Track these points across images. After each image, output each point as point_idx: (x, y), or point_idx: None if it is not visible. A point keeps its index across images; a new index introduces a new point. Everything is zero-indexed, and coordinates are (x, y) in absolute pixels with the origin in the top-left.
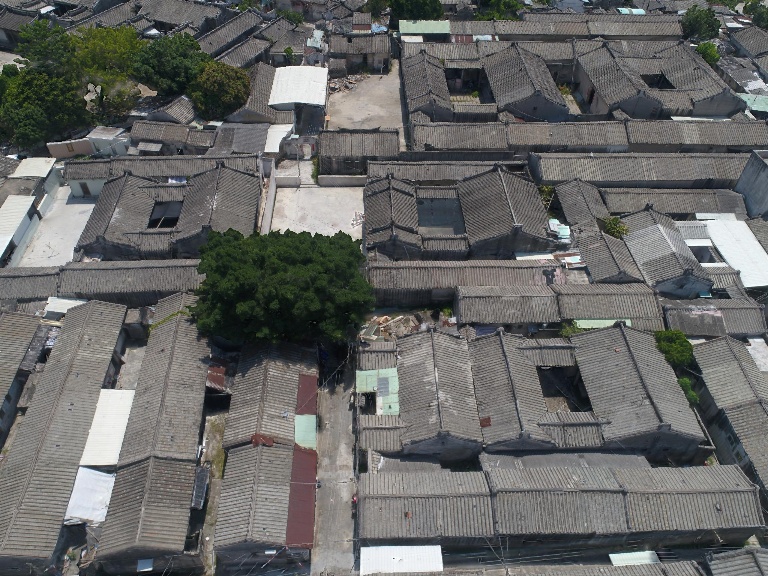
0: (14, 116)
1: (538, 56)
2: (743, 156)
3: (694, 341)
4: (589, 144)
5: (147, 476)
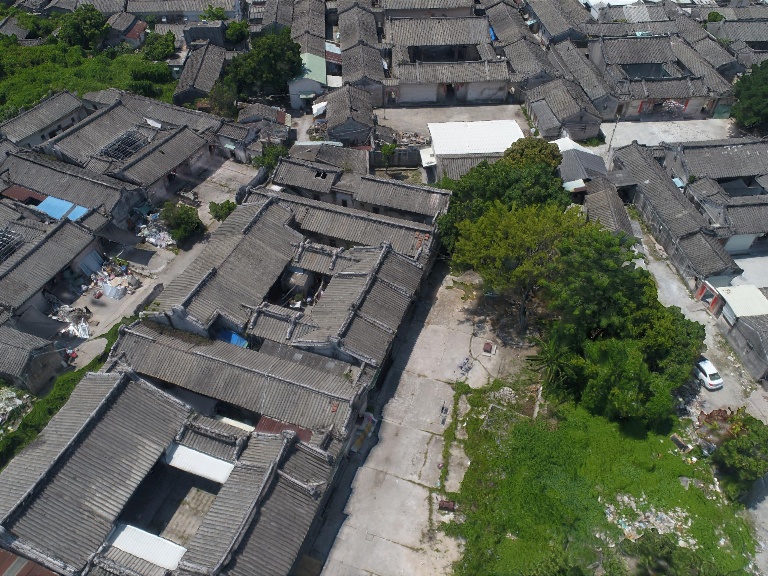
0: (695, 326)
1: None
2: None
3: None
4: None
5: None
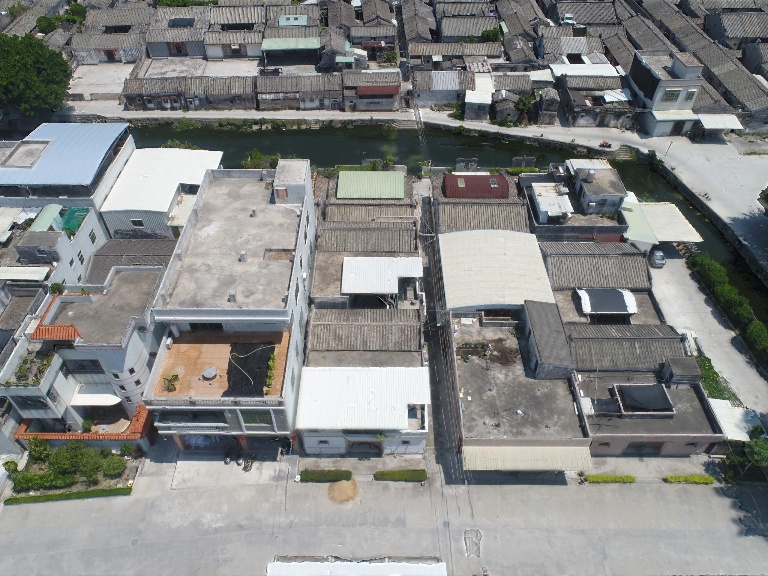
0: None
1: None
2: None
3: None
4: None
5: None
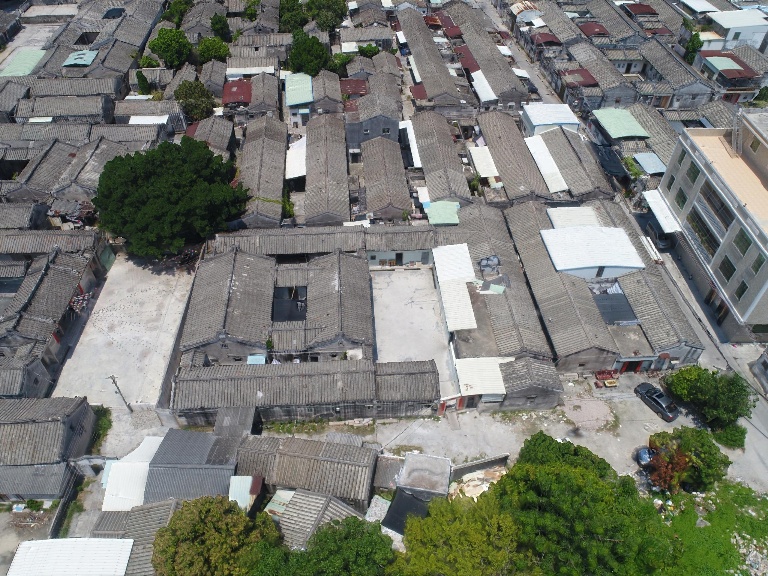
0: (560, 443)
1: None
2: None
3: None
4: None
5: None
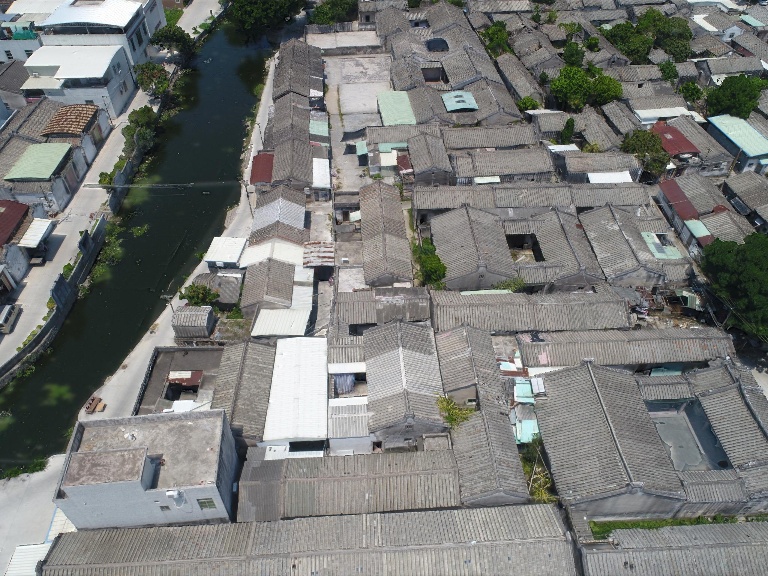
0: None
1: None
2: (186, 563)
3: None
4: None
5: None
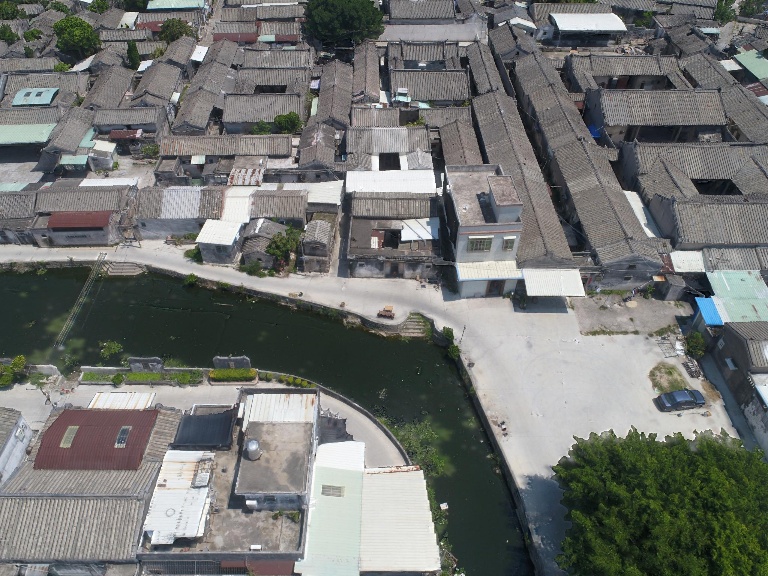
0: None
1: (726, 116)
2: None
3: (298, 140)
4: (545, 130)
5: (249, 7)
